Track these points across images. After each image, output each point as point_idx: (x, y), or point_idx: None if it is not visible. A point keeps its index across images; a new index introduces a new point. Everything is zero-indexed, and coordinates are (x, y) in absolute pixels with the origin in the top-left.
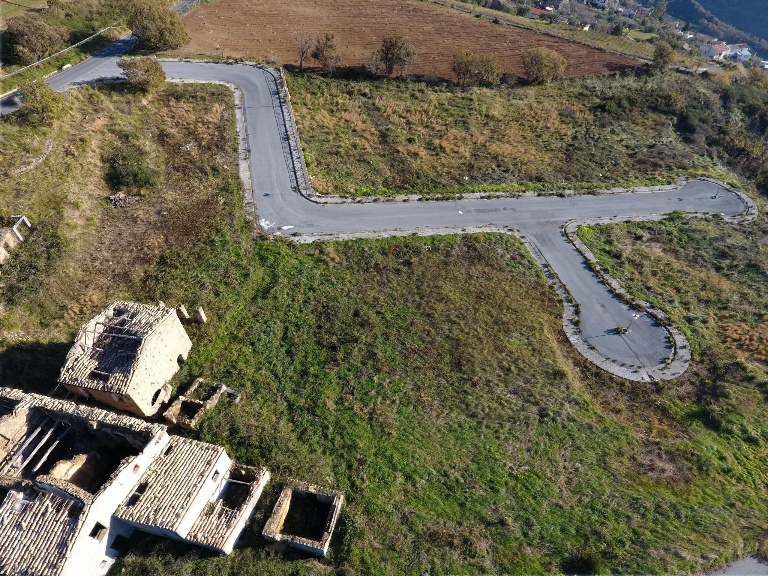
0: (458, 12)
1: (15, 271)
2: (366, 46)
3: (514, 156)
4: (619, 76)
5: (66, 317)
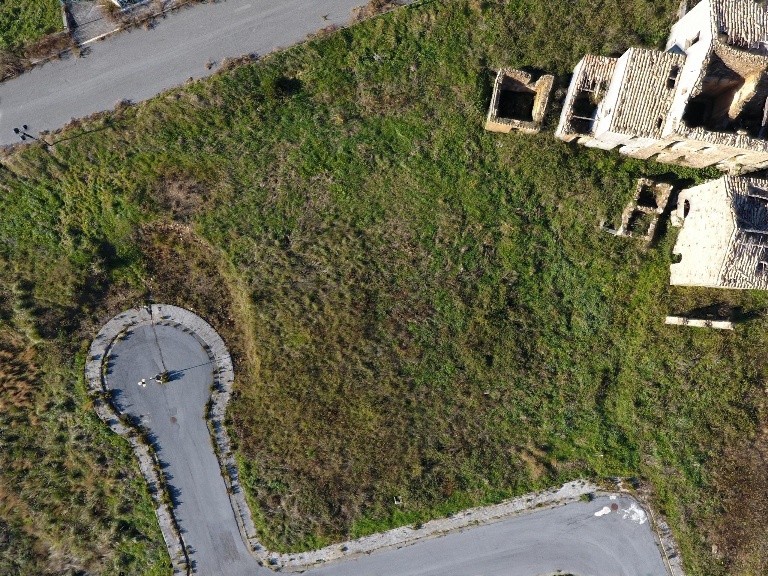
0: None
1: None
2: None
3: None
4: None
5: None
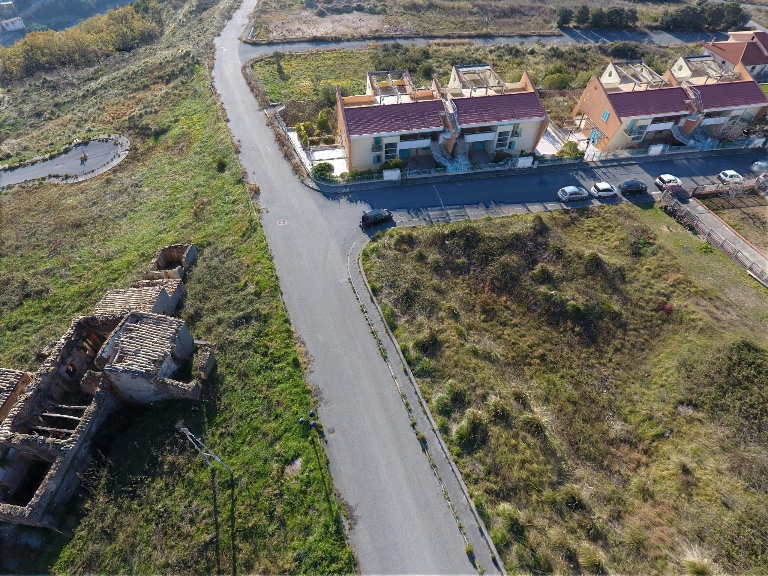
0: None
1: None
2: None
3: None
4: None
5: None
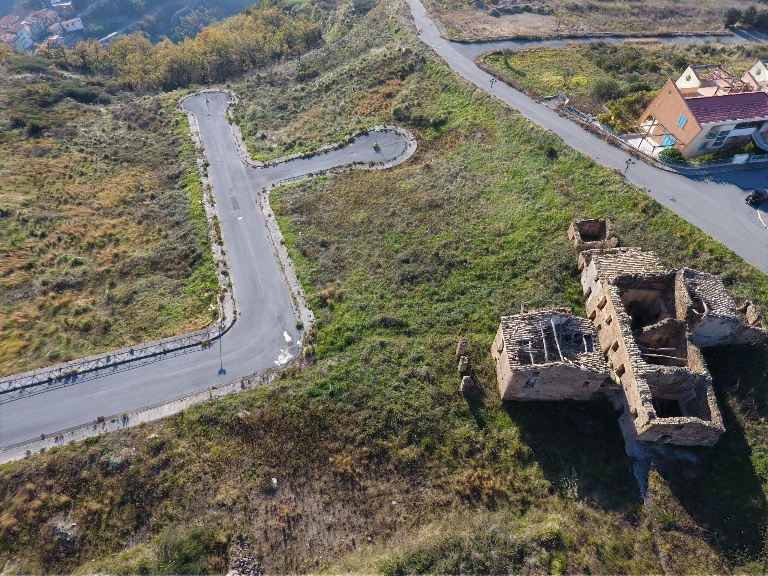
0: None
1: None
2: None
3: (125, 190)
4: None
5: None
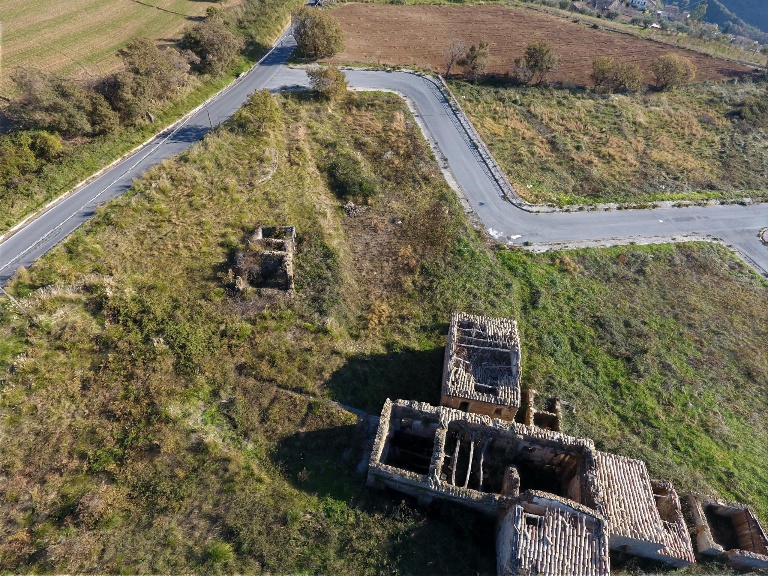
0: (556, 17)
1: (306, 282)
2: (492, 52)
3: (677, 164)
4: (737, 82)
5: (370, 328)
